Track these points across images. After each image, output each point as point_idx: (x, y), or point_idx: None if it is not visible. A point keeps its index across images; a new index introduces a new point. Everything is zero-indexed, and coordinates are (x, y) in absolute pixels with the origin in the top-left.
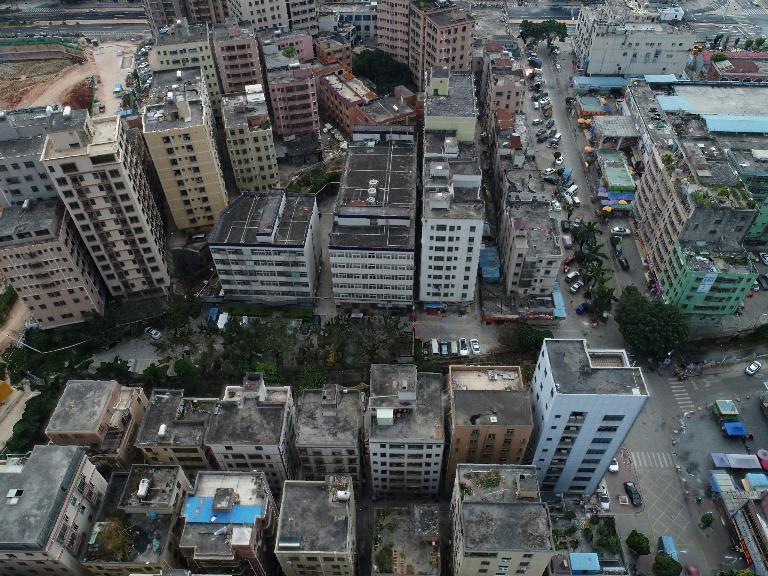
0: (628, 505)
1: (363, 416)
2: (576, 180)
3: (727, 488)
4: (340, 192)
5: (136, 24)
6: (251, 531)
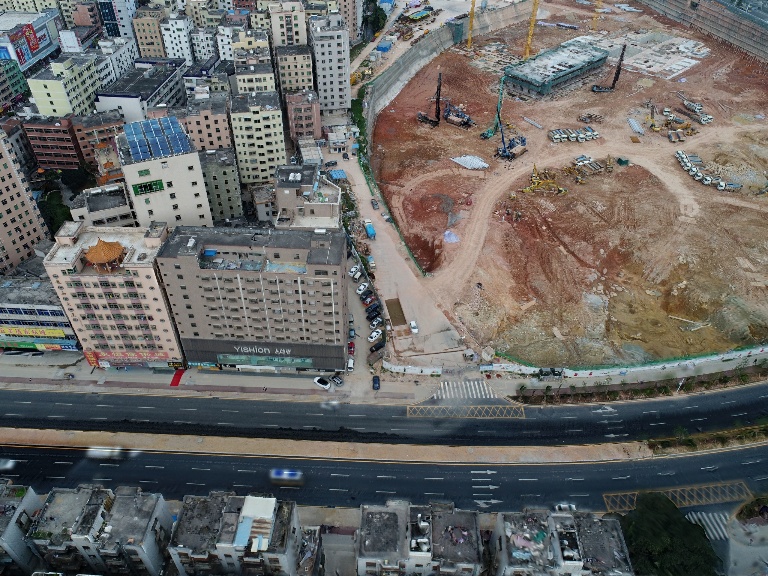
0: None
1: (194, 52)
2: None
3: None
4: (168, 78)
5: (434, 442)
6: (230, 7)
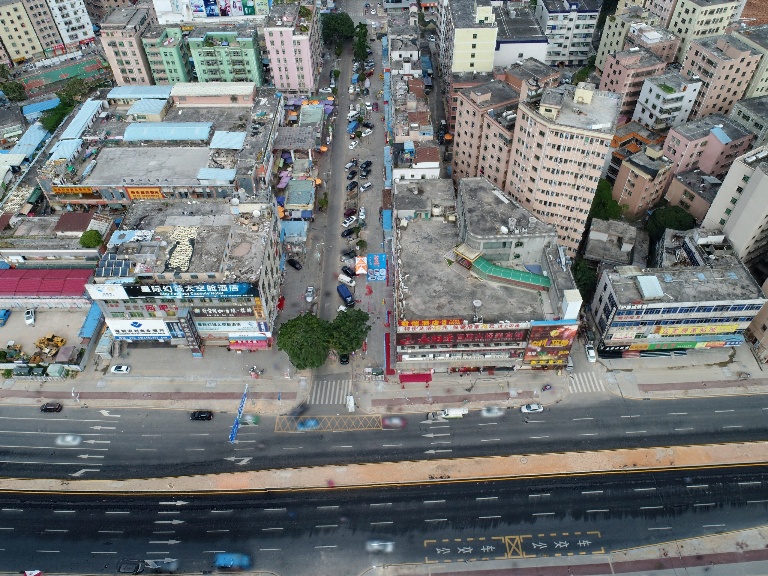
0: (370, 4)
1: None
2: (344, 130)
3: (331, 3)
4: None
5: None
6: None
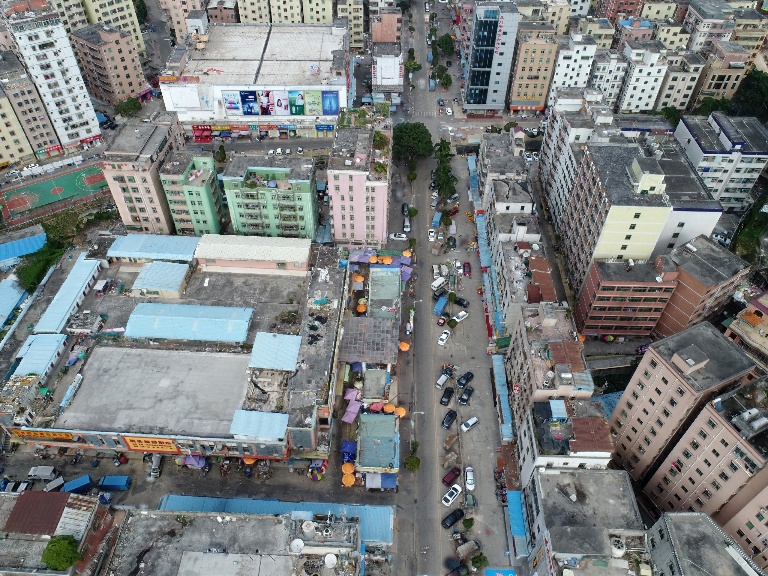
0: None
1: None
2: (428, 307)
3: None
4: (685, 157)
5: None
6: None
